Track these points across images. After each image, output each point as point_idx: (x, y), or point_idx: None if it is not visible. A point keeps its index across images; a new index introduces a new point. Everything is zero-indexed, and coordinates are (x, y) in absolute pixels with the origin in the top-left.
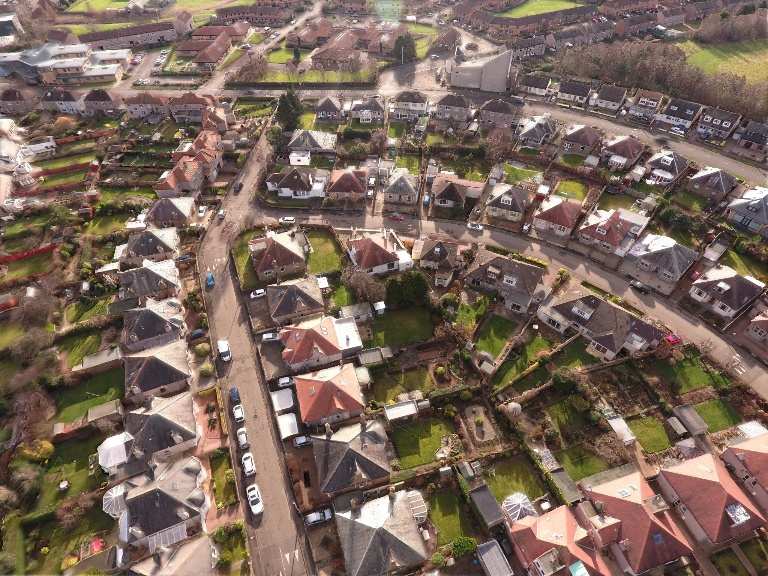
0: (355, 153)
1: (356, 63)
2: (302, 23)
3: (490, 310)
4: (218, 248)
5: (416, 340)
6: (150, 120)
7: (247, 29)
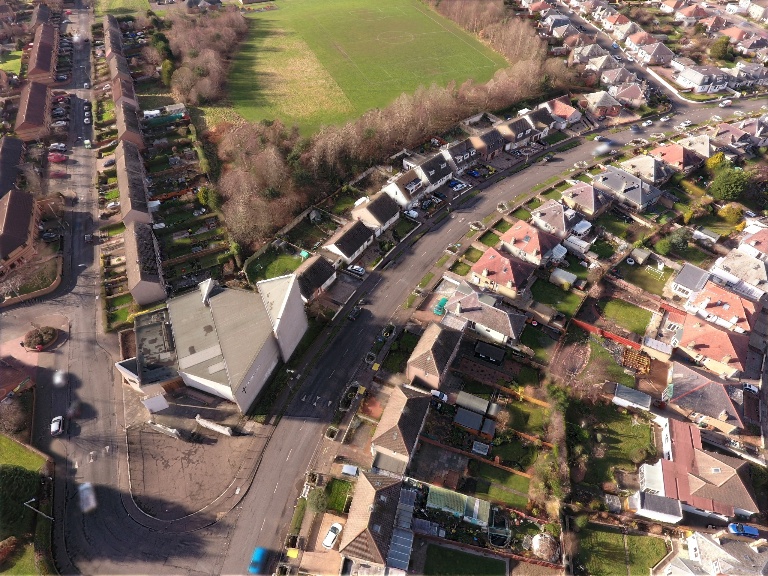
0: None
1: None
2: None
3: None
4: None
5: None
6: None
7: None
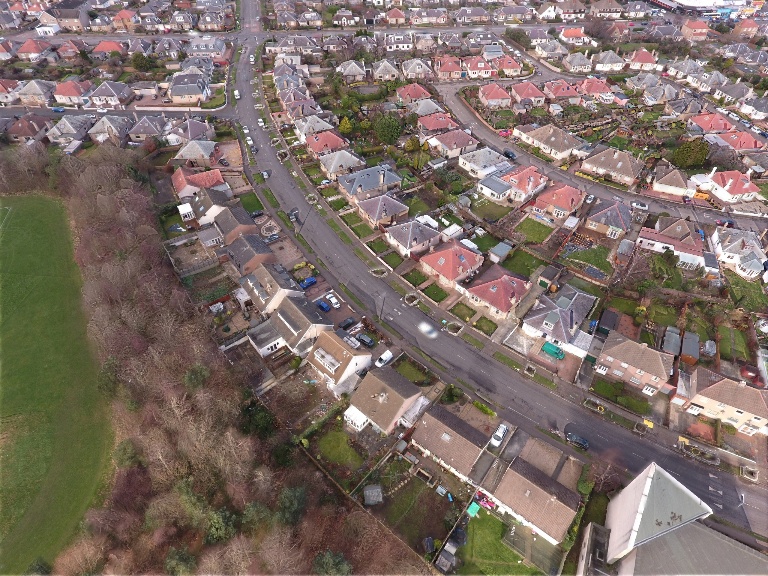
0: None
1: None
2: None
3: None
4: None
5: None
6: None
7: None
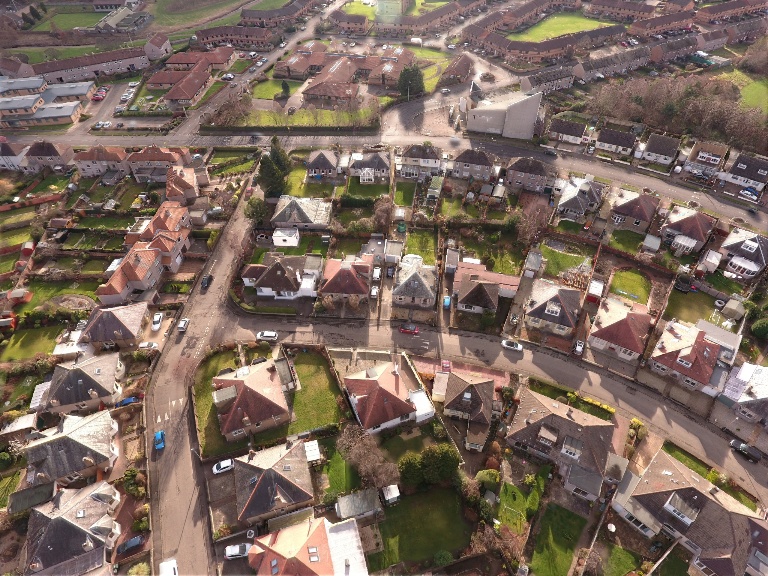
0: (355, 231)
1: (355, 104)
2: (293, 48)
3: (545, 495)
4: (174, 382)
5: (445, 562)
6: (105, 180)
7: (230, 55)
